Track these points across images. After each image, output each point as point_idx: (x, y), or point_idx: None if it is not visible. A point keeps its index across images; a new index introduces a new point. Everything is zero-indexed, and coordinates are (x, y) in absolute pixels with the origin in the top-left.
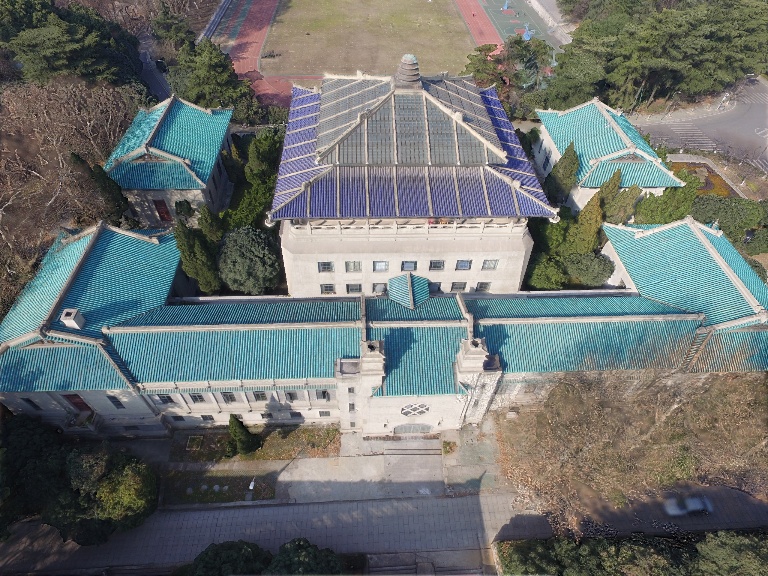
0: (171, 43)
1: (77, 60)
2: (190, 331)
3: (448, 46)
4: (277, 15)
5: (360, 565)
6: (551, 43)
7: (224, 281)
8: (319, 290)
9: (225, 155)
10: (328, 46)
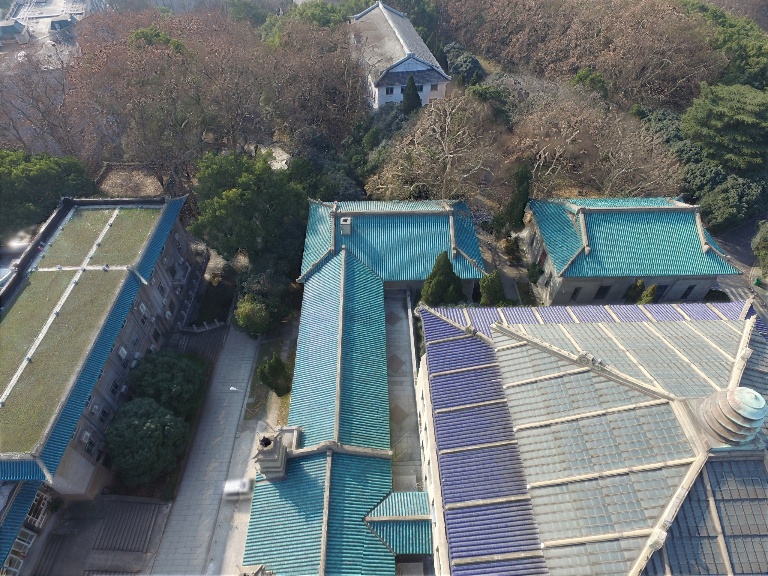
0: None
1: (737, 131)
2: None
3: None
4: None
5: (162, 494)
6: None
7: None
8: None
9: (637, 284)
10: None
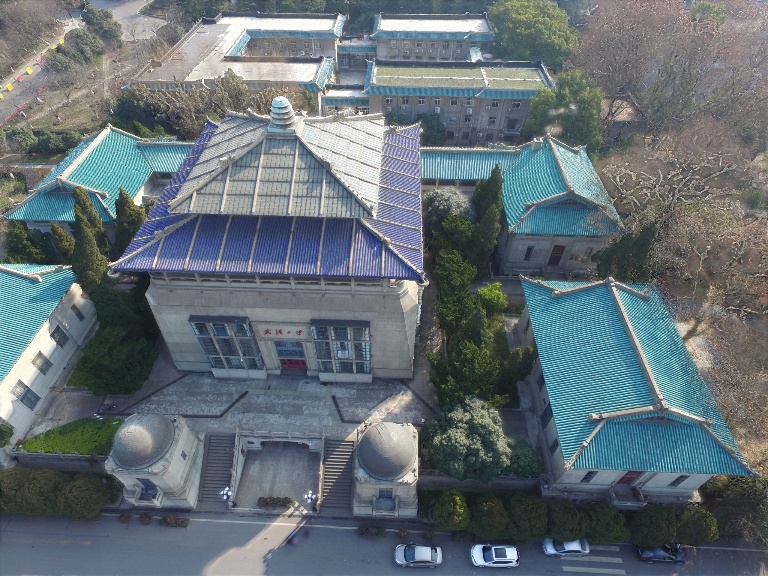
0: None
1: None
2: None
3: None
4: None
5: None
6: None
7: None
8: None
9: None
10: None
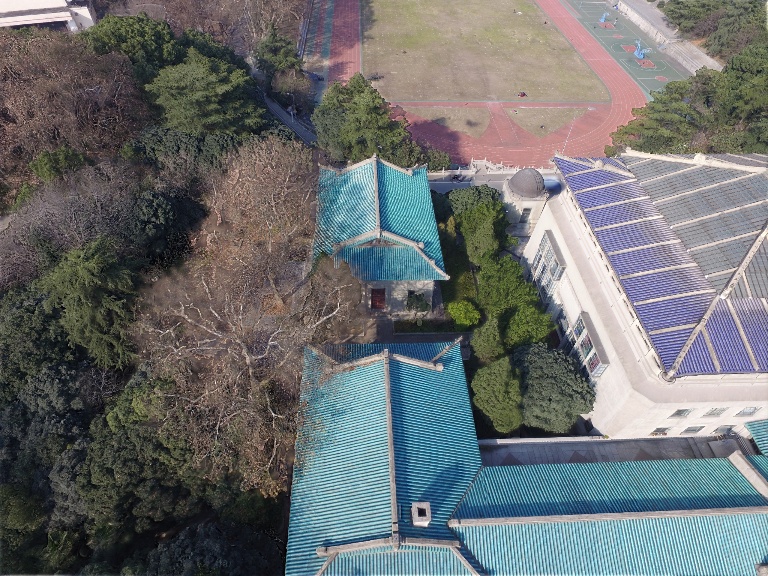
0: (293, 72)
1: (225, 102)
2: (559, 522)
3: (559, 66)
4: (364, 30)
5: None
6: (667, 62)
7: (525, 418)
8: (649, 432)
9: (442, 229)
10: (431, 66)
